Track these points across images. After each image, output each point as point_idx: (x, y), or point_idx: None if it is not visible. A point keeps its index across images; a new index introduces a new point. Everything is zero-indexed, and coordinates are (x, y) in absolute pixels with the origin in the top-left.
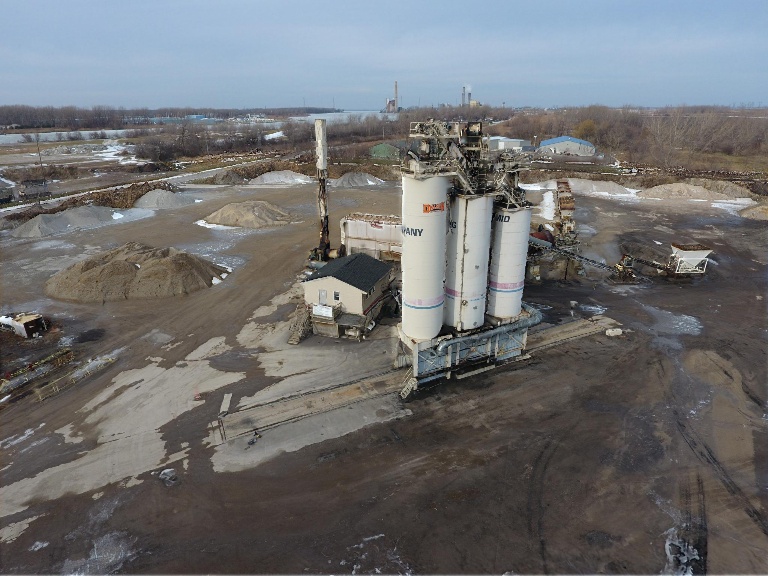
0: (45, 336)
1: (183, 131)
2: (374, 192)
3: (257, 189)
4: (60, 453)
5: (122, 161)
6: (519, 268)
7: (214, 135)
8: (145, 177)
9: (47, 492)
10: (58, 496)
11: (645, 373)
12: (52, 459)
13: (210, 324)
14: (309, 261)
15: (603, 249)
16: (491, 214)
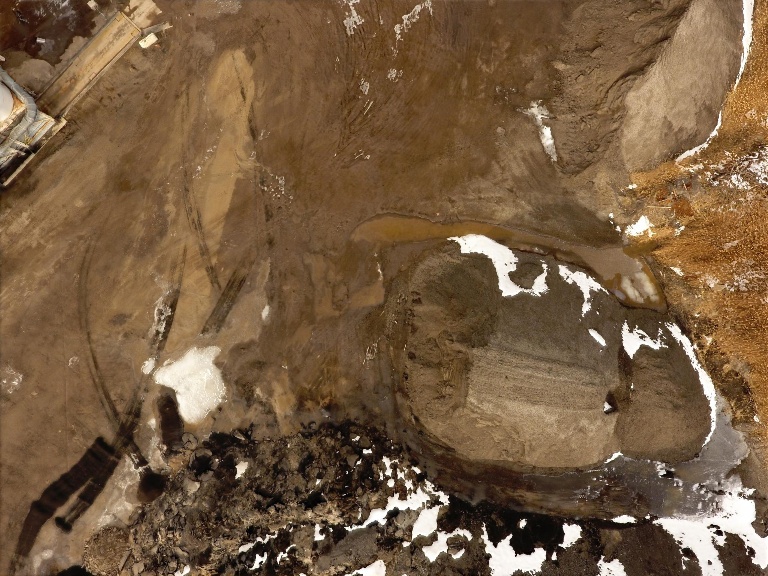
0: None
1: None
2: None
3: None
4: None
5: None
6: None
7: None
8: None
9: None
10: None
11: (170, 117)
12: None
13: None
14: None
15: None
16: None
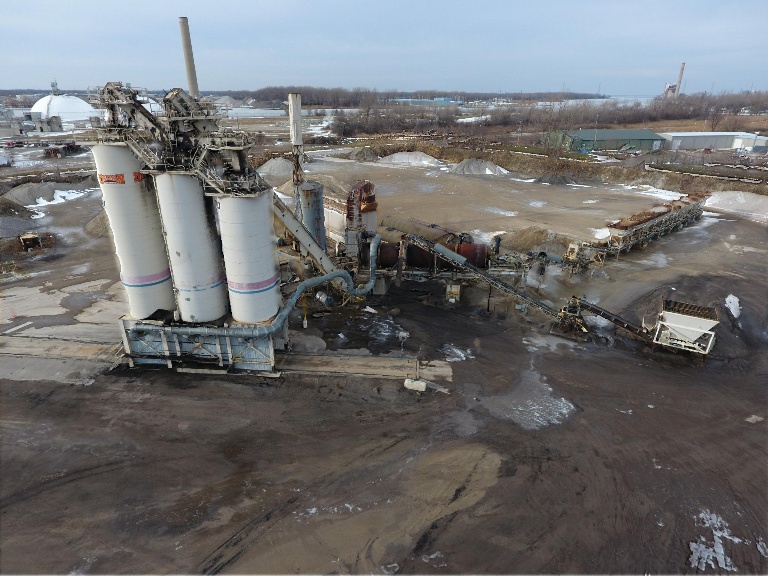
0: (33, 251)
1: (368, 109)
2: (474, 181)
3: (372, 167)
4: None
5: (318, 134)
6: (242, 267)
7: (402, 115)
8: (307, 148)
9: None
10: None
11: (356, 443)
12: None
13: None
14: None
15: (623, 288)
16: (194, 196)
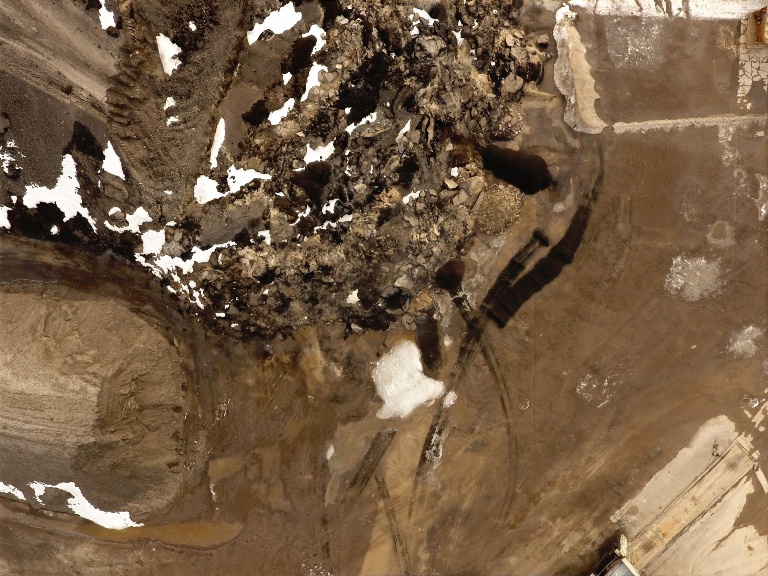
0: None
1: None
2: None
3: None
4: None
5: None
6: None
7: None
8: None
9: None
10: None
11: None
12: None
13: None
14: None
15: None
16: None
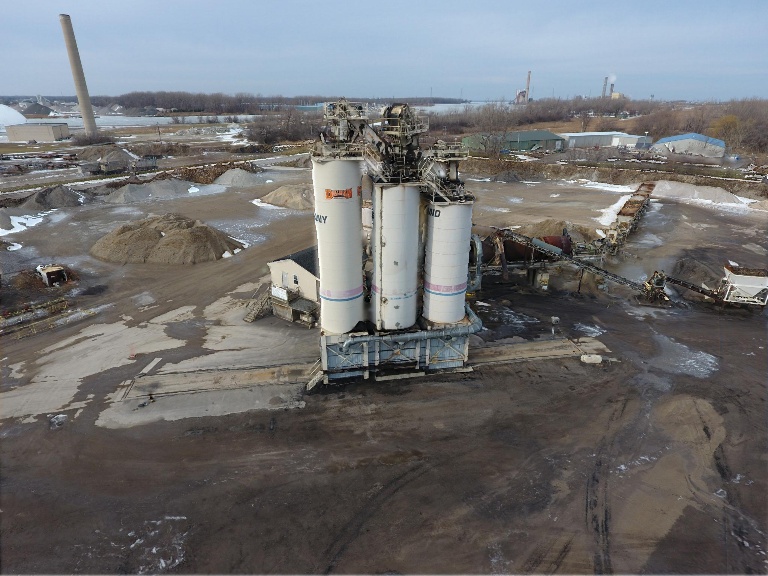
0: (62, 286)
1: (288, 116)
2: None
3: None
4: None
5: (235, 142)
6: (454, 270)
7: (319, 121)
8: (242, 157)
9: None
10: None
11: (596, 411)
12: None
13: (192, 293)
14: None
15: (654, 264)
16: (415, 206)
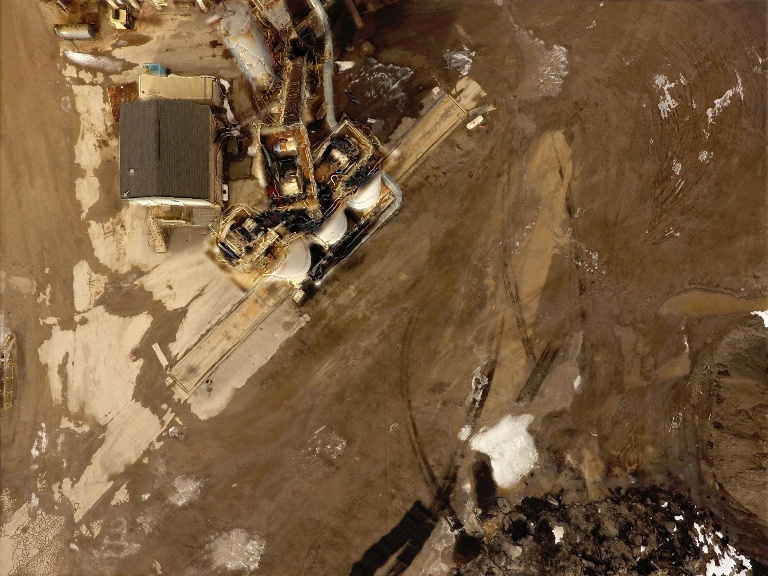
0: None
1: None
2: None
3: None
4: (86, 442)
5: None
6: None
7: None
8: None
9: (113, 470)
10: (122, 469)
11: (492, 195)
12: (87, 448)
13: (49, 243)
14: (56, 32)
15: None
16: None
